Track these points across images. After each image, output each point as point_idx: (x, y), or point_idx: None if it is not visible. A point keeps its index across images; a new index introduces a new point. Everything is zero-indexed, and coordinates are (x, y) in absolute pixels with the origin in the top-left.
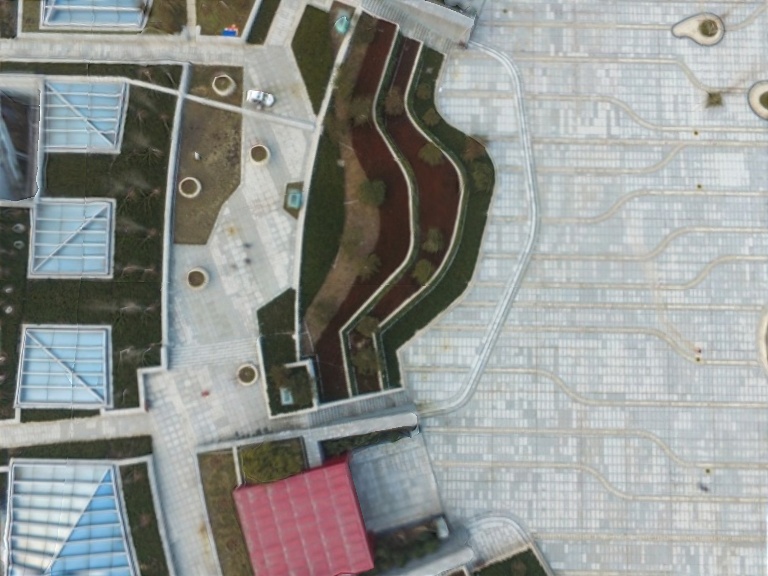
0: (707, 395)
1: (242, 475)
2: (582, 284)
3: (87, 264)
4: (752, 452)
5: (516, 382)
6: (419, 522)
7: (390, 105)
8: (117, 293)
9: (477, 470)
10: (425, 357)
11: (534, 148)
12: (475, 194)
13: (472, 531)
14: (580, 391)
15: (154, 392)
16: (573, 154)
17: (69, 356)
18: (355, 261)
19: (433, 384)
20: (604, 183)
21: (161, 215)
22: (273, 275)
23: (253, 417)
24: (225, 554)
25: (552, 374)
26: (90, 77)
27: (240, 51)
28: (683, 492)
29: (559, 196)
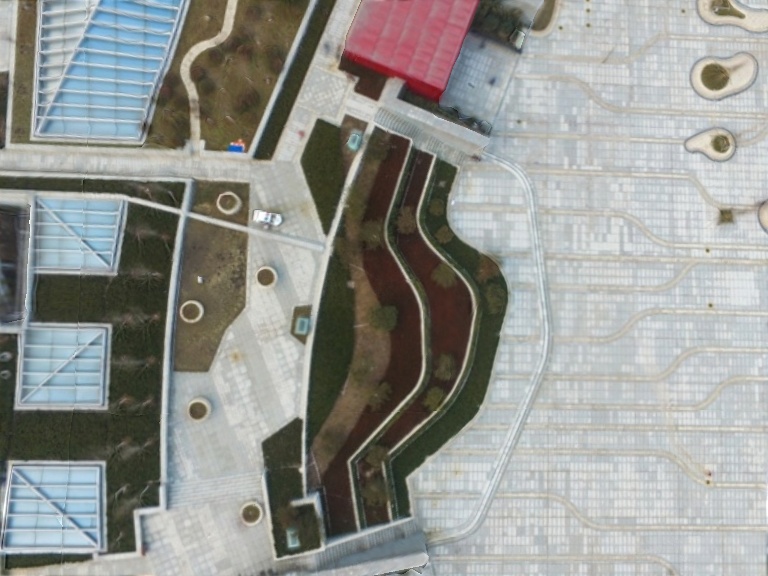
0: (716, 518)
1: None
2: (594, 405)
3: (80, 394)
4: (760, 575)
5: (527, 507)
6: None
7: (403, 225)
8: (112, 426)
9: None
10: (435, 483)
11: (547, 264)
12: (488, 316)
13: None
14: (591, 516)
15: (152, 533)
16: (586, 271)
17: (59, 495)
18: (365, 388)
19: (443, 511)
20: (617, 301)
21: (161, 342)
22: (279, 404)
23: (257, 558)
24: None
25: (563, 499)
26: (85, 193)
27: (246, 166)
28: None
29: (572, 314)
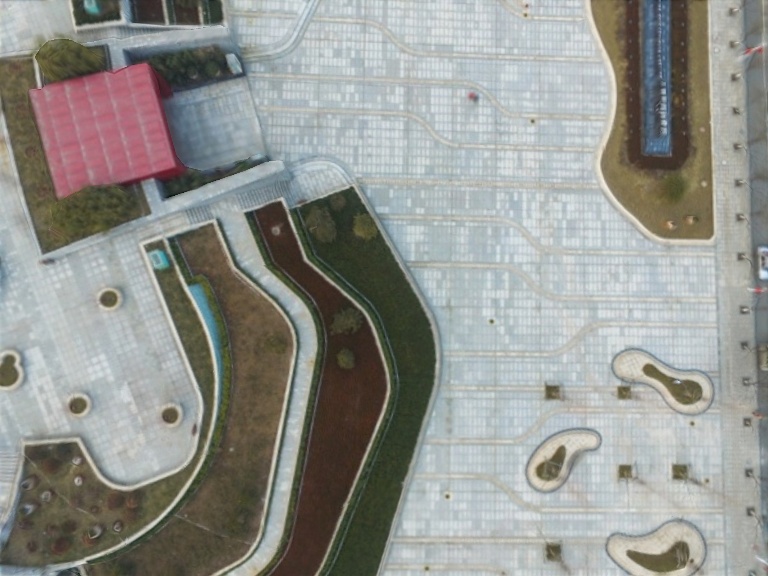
0: (533, 49)
1: (42, 81)
2: None
3: None
4: (576, 104)
5: (344, 32)
6: (240, 161)
7: None
8: None
9: (303, 116)
10: (251, 2)
11: None
12: None
13: (296, 173)
14: (408, 42)
15: None
16: None
17: None
18: None
19: (258, 29)
20: None
21: None
22: None
23: (58, 30)
24: (23, 161)
25: (381, 25)
26: None
27: None
28: (508, 141)
29: None
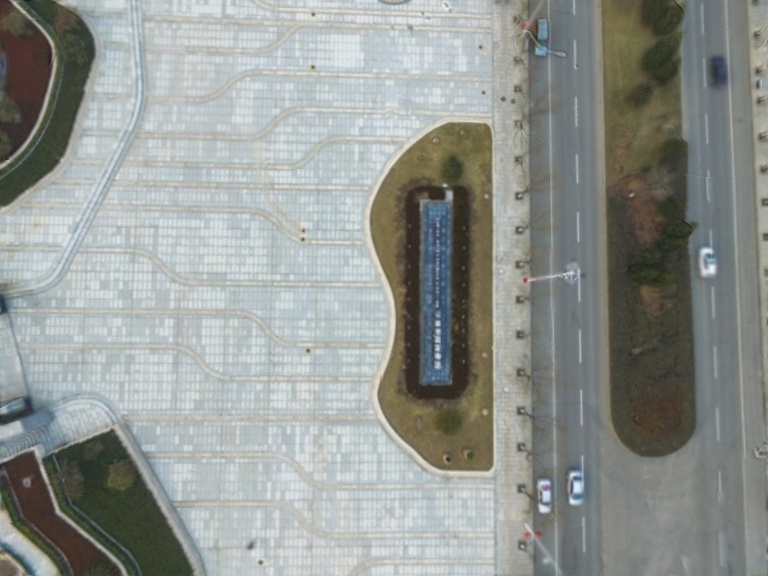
0: (310, 275)
1: None
2: (187, 163)
3: None
4: (354, 331)
5: (112, 262)
6: None
7: None
8: None
9: (67, 352)
10: (13, 236)
11: (145, 26)
12: (65, 66)
13: (57, 414)
14: (179, 271)
15: None
16: (185, 33)
17: None
18: None
19: (20, 263)
20: (216, 62)
21: None
22: None
23: None
24: None
25: (151, 254)
26: None
27: None
28: (282, 372)
29: (168, 75)
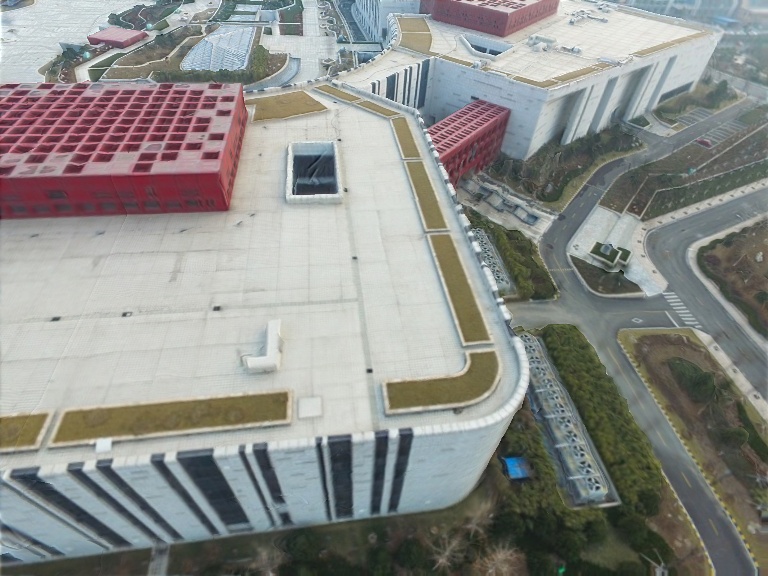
0: None
1: None
2: None
3: None
4: None
5: (120, 3)
6: None
7: None
8: (235, 2)
9: None
10: None
11: None
12: None
13: None
14: (100, 2)
15: None
16: None
17: None
18: None
19: None
20: None
21: None
22: None
23: None
24: None
25: None
26: None
27: None
28: None
29: None
